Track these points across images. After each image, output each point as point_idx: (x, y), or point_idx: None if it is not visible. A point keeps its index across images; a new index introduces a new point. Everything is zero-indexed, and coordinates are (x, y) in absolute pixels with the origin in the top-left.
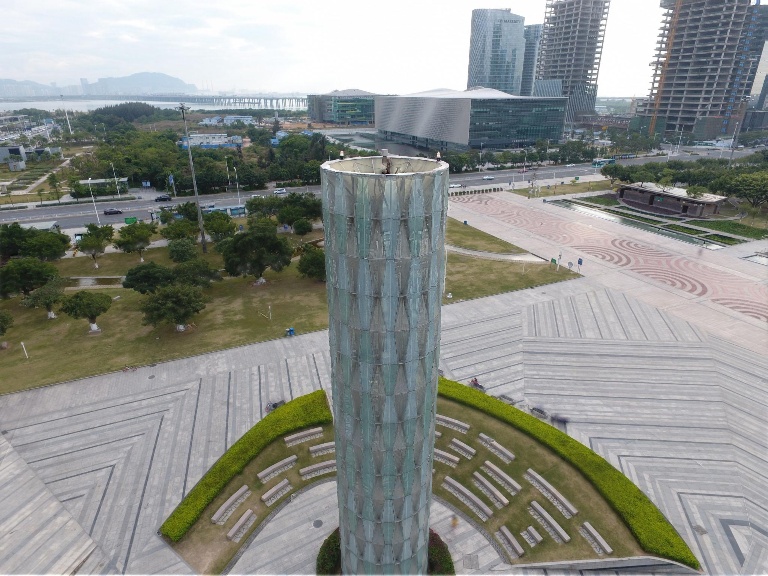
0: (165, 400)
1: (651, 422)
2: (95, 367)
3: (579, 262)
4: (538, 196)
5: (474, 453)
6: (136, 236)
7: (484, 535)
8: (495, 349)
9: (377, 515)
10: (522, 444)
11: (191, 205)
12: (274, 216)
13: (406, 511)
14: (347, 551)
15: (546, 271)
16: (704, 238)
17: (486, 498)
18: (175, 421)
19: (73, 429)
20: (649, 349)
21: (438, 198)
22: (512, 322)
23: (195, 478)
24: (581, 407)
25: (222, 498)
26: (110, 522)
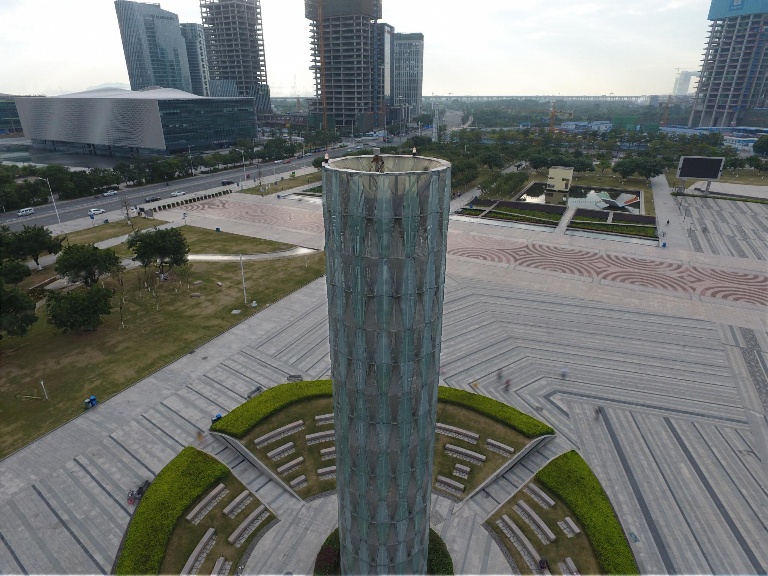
0: None
1: (470, 351)
2: None
3: None
4: (270, 193)
5: None
6: None
7: None
8: None
9: (408, 511)
10: None
11: None
12: None
13: None
14: (371, 569)
15: (323, 259)
16: None
17: None
18: None
19: None
20: None
21: None
22: None
23: None
24: None
25: None
26: None
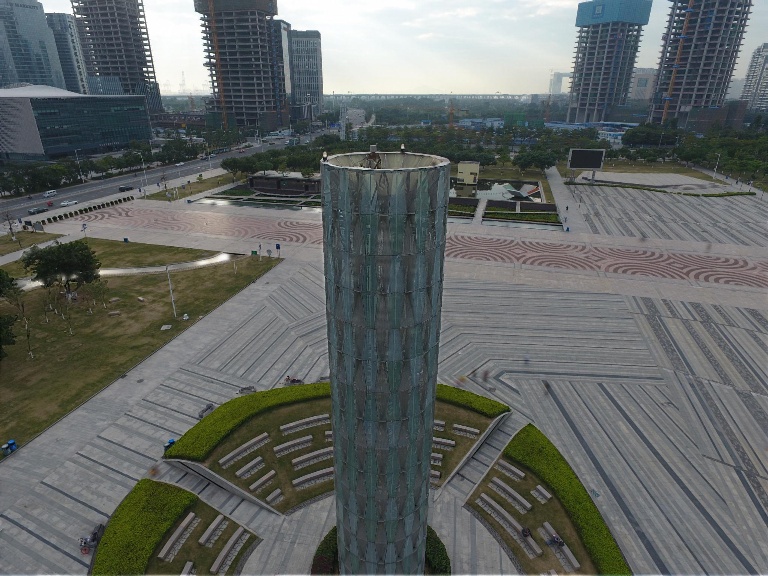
0: None
1: None
2: None
3: (277, 247)
4: (178, 198)
5: None
6: None
7: None
8: (276, 345)
9: None
10: None
11: None
12: None
13: None
14: (379, 569)
15: (252, 264)
16: None
17: None
18: None
19: None
20: None
21: None
22: (267, 317)
23: None
24: None
25: None
26: None
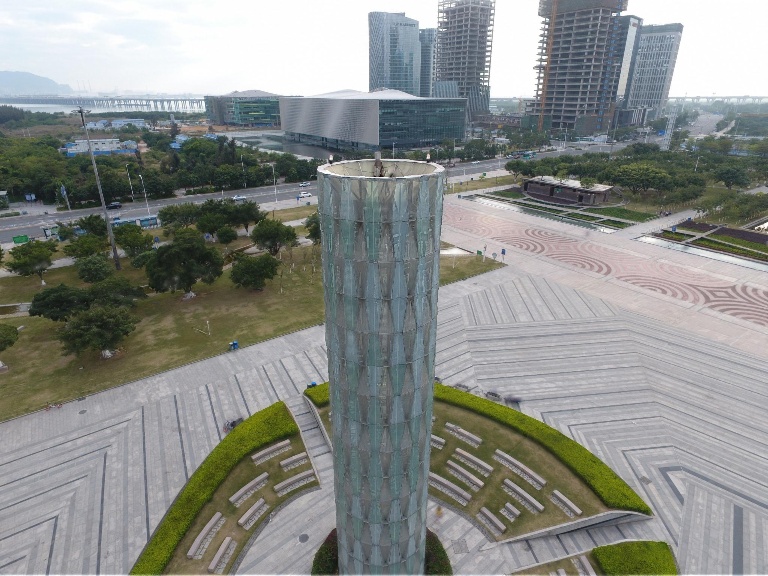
0: (104, 435)
1: (589, 392)
2: (9, 409)
3: (502, 252)
4: (453, 192)
5: (444, 443)
6: (34, 256)
7: (467, 519)
8: (442, 341)
9: (384, 517)
10: (486, 427)
11: (95, 218)
12: (192, 225)
13: (411, 508)
14: (350, 559)
15: (474, 263)
16: (600, 223)
17: (462, 484)
18: (121, 456)
19: None
20: (575, 326)
21: (439, 199)
22: (452, 314)
23: (158, 514)
24: (528, 386)
25: (195, 530)
26: None
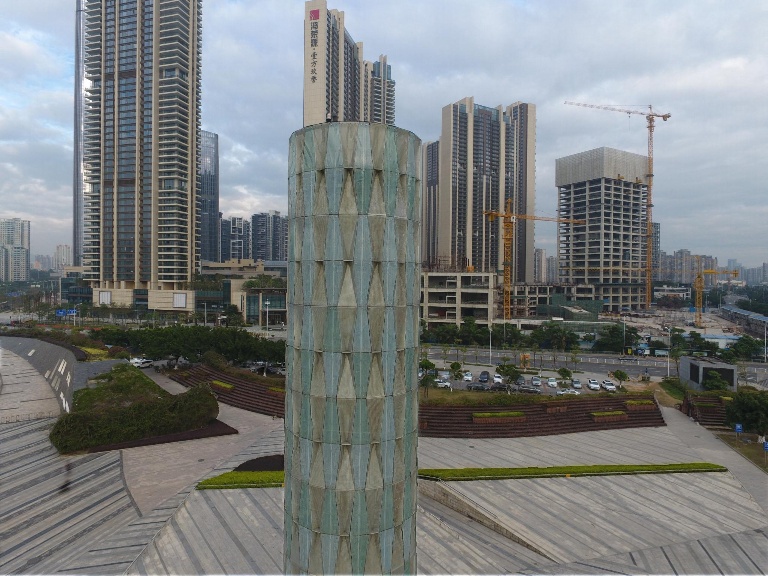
0: None
1: None
2: None
3: None
4: None
5: None
6: None
7: None
8: None
9: None
10: None
11: None
12: None
13: None
14: None
15: None
16: None
17: None
18: None
19: (767, 569)
20: None
21: None
22: None
23: None
24: None
25: None
26: (587, 574)
